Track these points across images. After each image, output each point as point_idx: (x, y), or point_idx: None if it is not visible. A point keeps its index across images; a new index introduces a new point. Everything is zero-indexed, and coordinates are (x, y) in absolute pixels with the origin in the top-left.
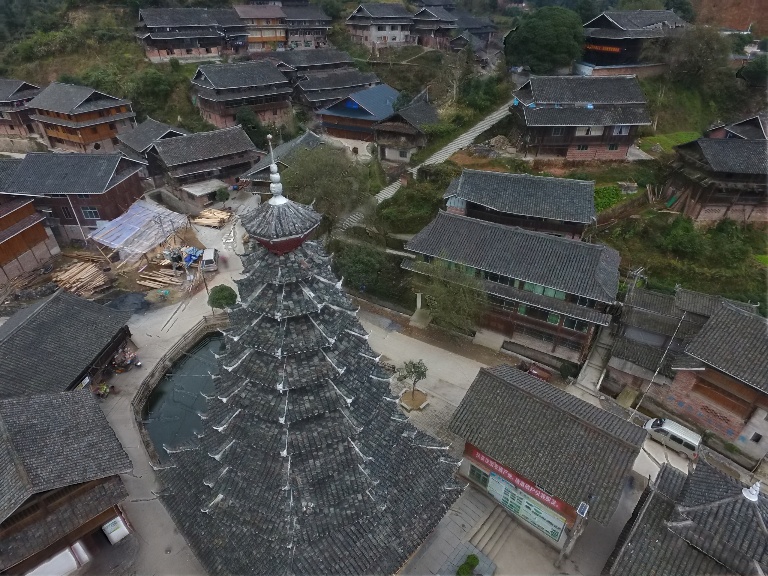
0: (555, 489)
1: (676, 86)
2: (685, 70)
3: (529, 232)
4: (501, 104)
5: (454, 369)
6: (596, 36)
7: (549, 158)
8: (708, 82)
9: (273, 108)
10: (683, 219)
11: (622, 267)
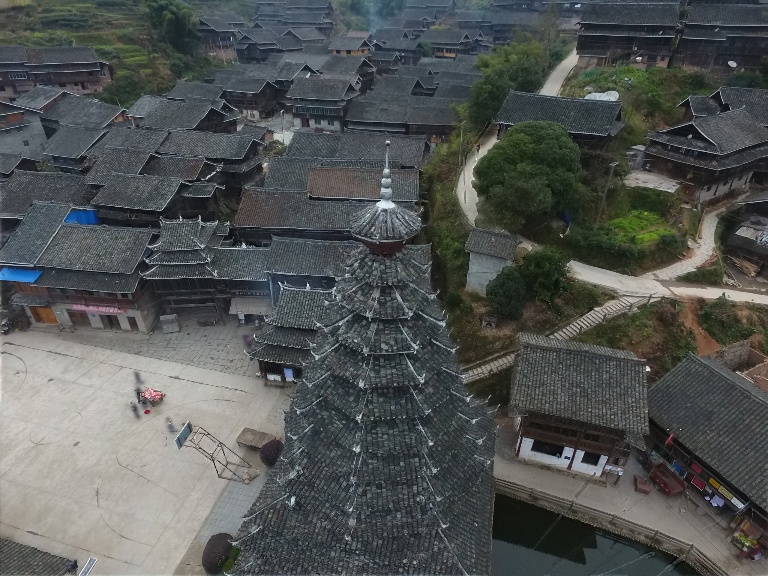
0: None
1: None
2: None
3: None
4: None
5: None
6: None
7: None
8: None
9: None
10: None
11: None
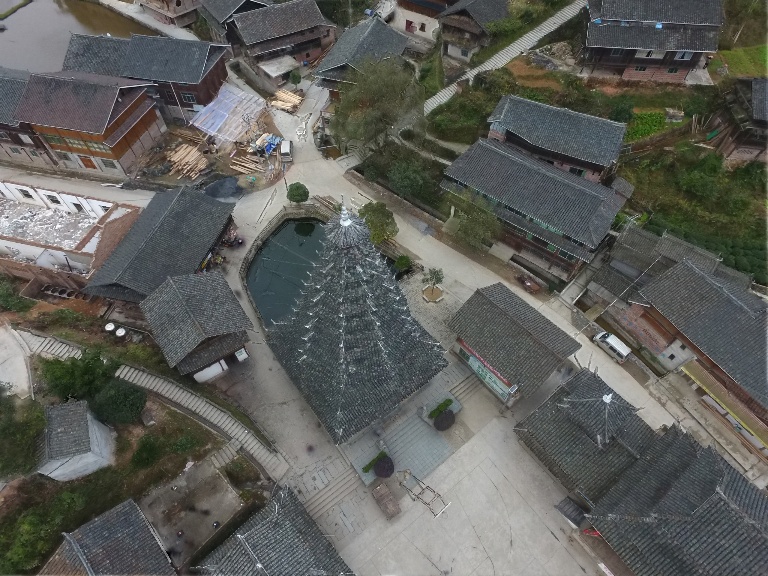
0: (504, 374)
1: None
2: None
3: (549, 174)
4: None
5: (468, 273)
6: None
7: (604, 76)
8: None
9: None
10: (715, 155)
11: (635, 200)
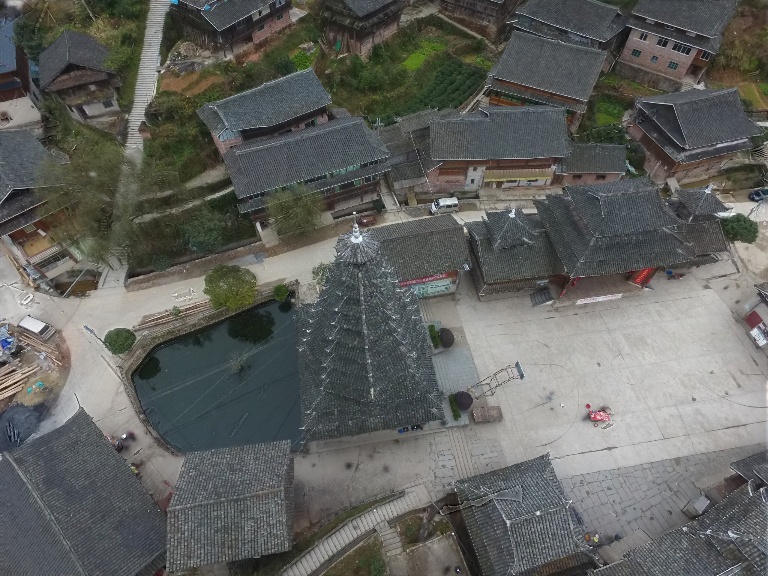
0: (446, 269)
1: None
2: None
3: (312, 134)
4: (147, 1)
5: (325, 253)
6: None
7: (242, 49)
8: None
9: None
10: (354, 57)
11: None
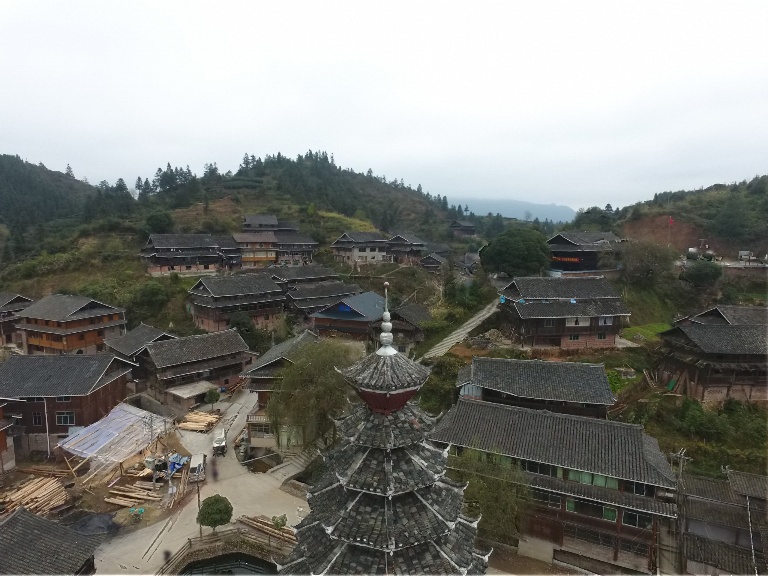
0: None
1: (633, 287)
2: (638, 274)
3: (559, 415)
4: (486, 303)
5: None
6: (554, 250)
7: (545, 348)
8: (657, 284)
9: (265, 314)
10: (690, 401)
11: None
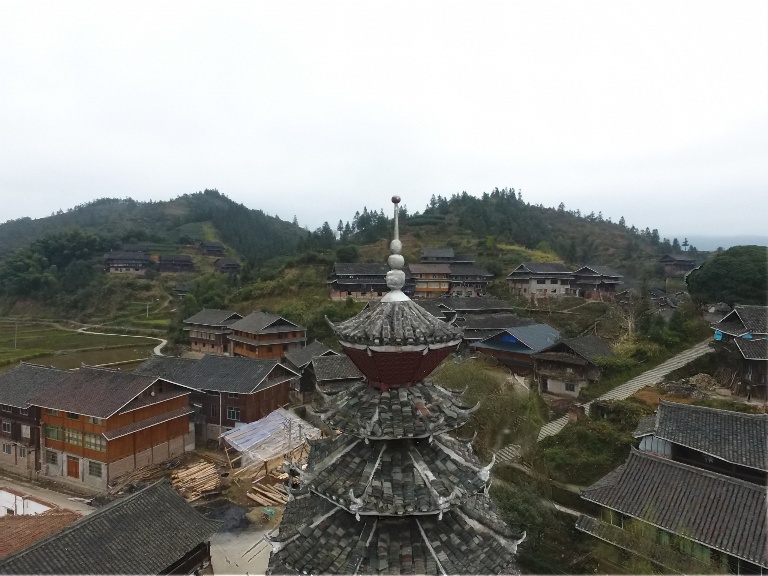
0: None
1: None
2: None
3: None
4: (694, 342)
5: None
6: None
7: None
8: None
9: None
10: None
11: None
